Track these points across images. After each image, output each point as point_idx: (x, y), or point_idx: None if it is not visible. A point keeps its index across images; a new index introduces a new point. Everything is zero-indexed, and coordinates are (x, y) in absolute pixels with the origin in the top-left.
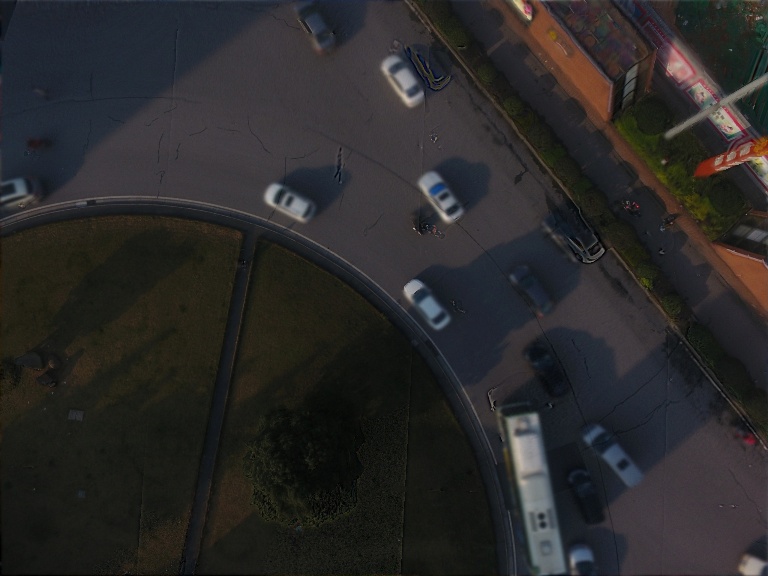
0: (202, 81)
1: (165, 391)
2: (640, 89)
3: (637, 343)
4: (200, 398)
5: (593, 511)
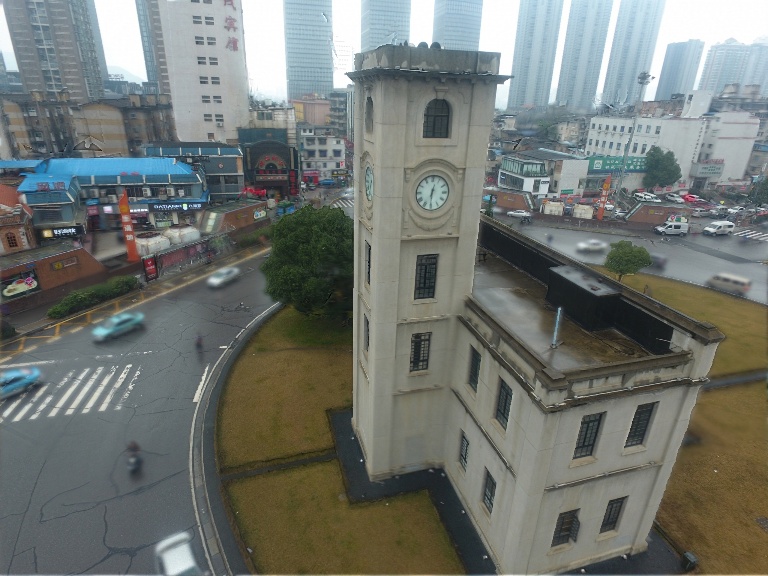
0: None
1: None
2: None
3: None
4: (760, 362)
5: None
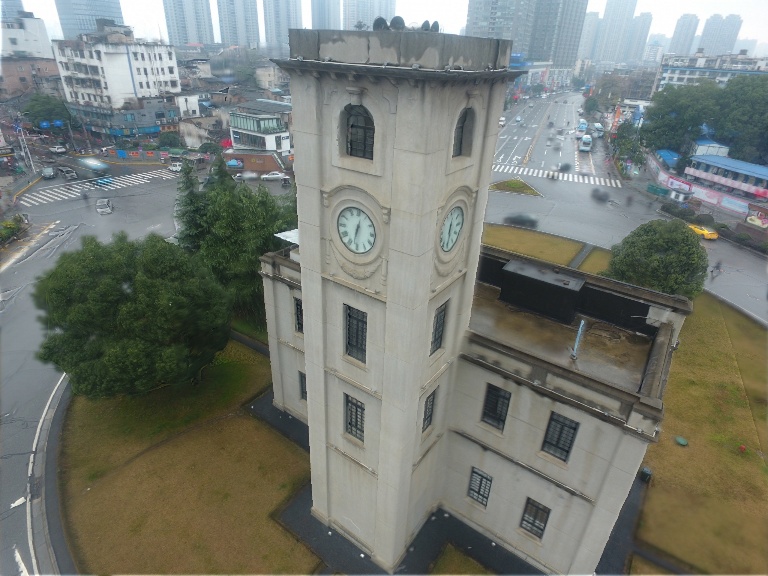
0: None
1: None
2: None
3: None
4: None
5: None
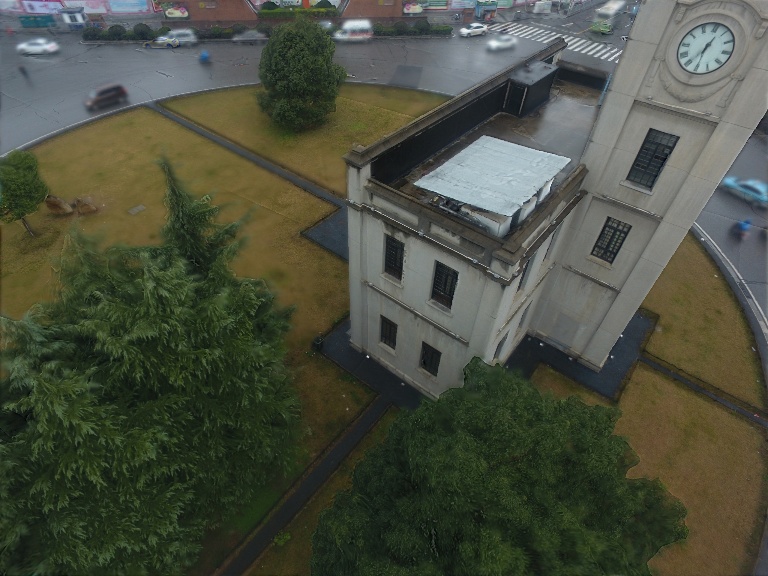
0: (38, 92)
1: (188, 162)
2: (255, 8)
3: (367, 45)
4: None
5: (440, 71)
